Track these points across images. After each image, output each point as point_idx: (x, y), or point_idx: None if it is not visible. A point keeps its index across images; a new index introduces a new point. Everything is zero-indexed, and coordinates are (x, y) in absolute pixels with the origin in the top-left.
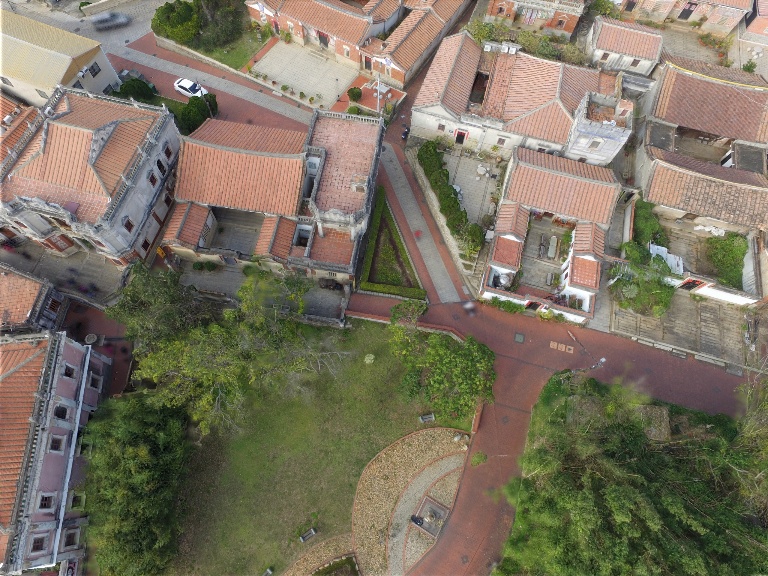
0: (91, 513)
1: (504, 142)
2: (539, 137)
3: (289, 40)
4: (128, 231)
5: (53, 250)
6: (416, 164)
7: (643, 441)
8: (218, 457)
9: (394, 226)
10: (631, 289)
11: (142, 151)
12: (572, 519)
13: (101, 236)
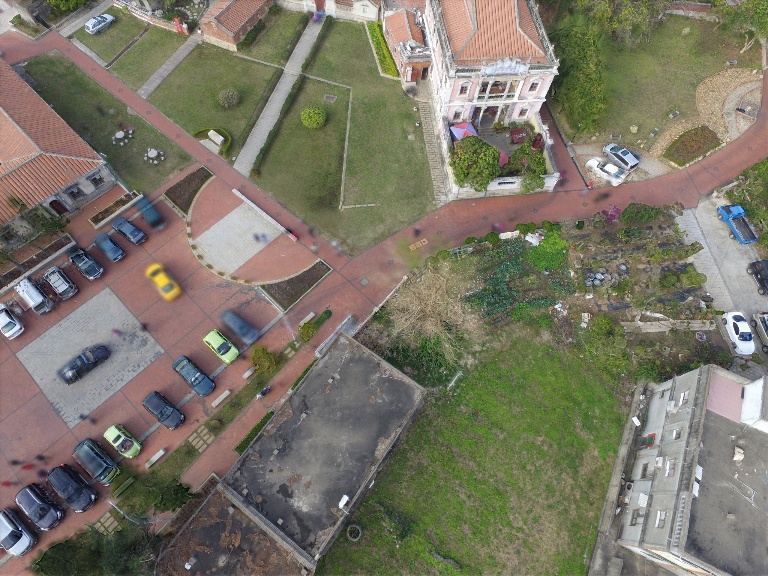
0: (572, 65)
1: None
2: None
3: None
4: None
5: None
6: None
7: None
8: None
9: None
10: None
11: None
12: None
13: None
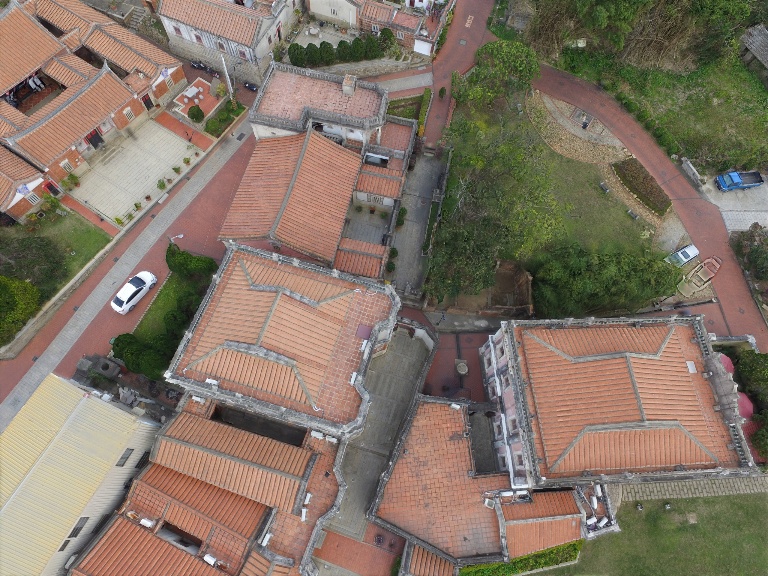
0: None
1: (295, 2)
2: None
3: (77, 180)
4: None
5: None
6: None
7: None
8: None
9: None
10: None
11: (297, 260)
12: (575, 46)
13: None
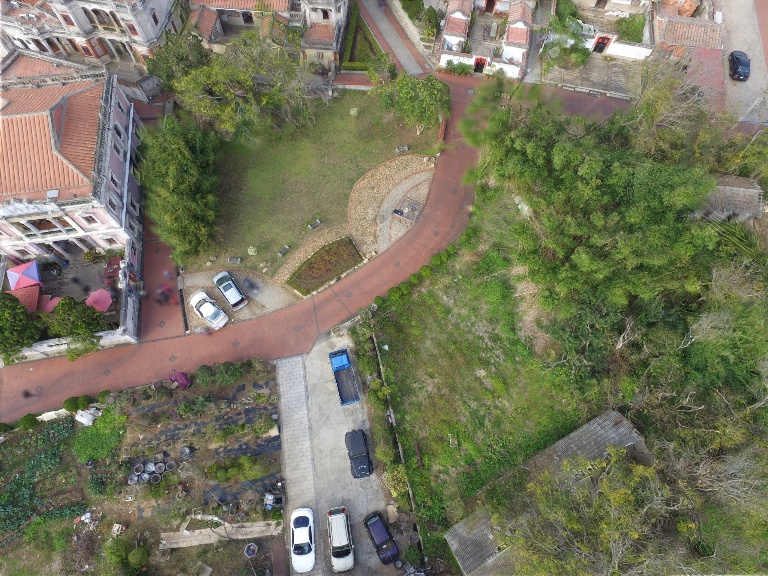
0: (150, 185)
1: None
2: None
3: None
4: (155, 23)
5: (91, 58)
6: None
7: (564, 132)
8: (240, 183)
9: (367, 29)
10: (555, 50)
11: None
12: None
13: (136, 18)
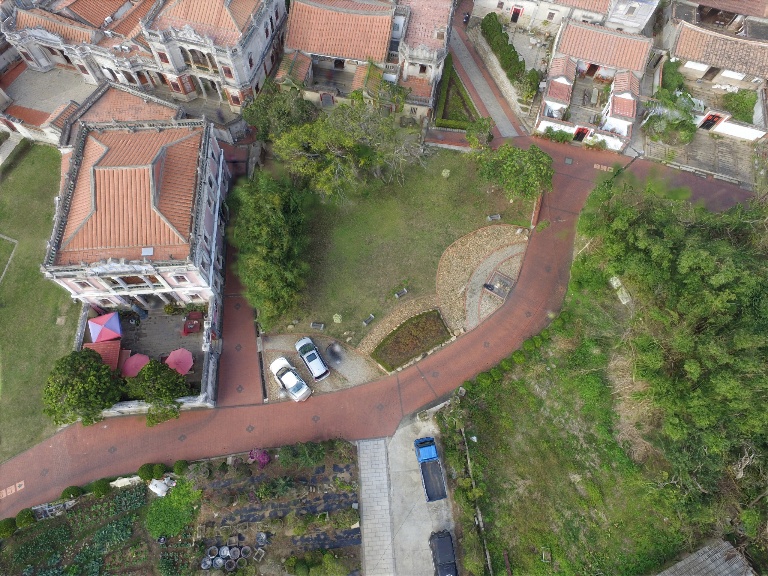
0: (242, 245)
1: (553, 16)
2: (584, 8)
3: None
4: (250, 67)
5: (179, 93)
6: (478, 37)
7: (674, 220)
8: (325, 241)
9: (460, 84)
10: (661, 124)
11: (264, 1)
12: (615, 287)
13: (234, 62)
